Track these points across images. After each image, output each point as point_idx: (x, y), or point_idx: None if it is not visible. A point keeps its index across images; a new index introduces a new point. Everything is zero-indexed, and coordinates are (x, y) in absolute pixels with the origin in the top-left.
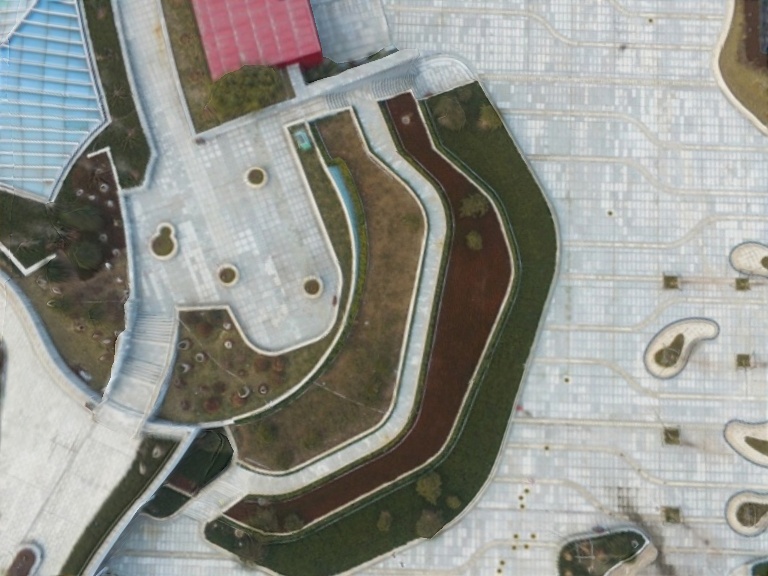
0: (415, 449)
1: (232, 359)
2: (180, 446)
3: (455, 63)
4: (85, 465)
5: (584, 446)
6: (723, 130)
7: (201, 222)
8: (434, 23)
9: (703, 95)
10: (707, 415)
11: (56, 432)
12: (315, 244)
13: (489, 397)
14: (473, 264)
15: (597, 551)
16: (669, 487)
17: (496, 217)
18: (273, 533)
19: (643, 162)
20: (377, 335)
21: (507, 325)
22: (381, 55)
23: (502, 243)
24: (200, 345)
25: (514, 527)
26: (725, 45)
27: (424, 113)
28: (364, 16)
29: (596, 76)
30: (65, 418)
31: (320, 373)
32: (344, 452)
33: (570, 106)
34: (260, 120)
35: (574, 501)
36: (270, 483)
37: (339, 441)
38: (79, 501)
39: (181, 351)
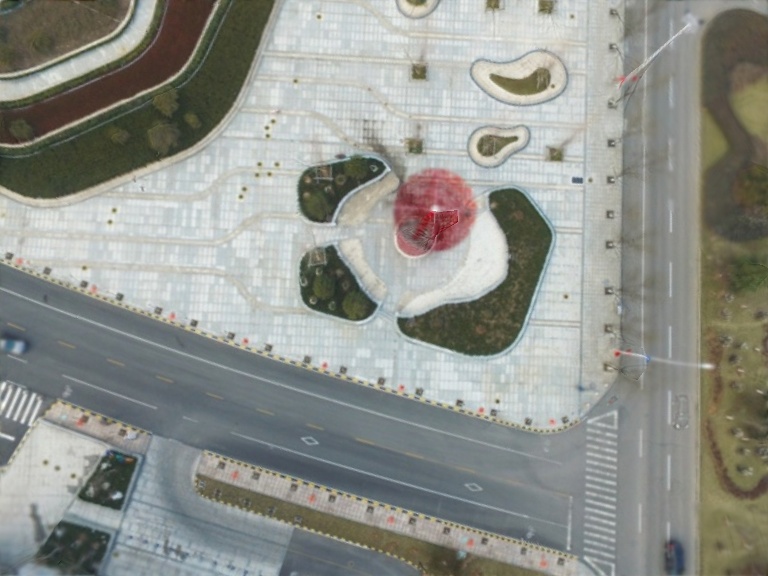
0: (154, 66)
1: None
2: None
3: None
4: None
5: (333, 80)
6: None
7: None
8: None
9: None
10: (455, 54)
11: None
12: None
13: (236, 24)
14: None
15: (336, 173)
16: (414, 121)
17: None
18: (3, 144)
19: None
20: None
21: None
22: None
23: None
24: None
25: (258, 155)
26: None
27: None
28: None
29: None
30: None
31: None
32: (77, 60)
33: None
34: None
35: (320, 132)
36: None
37: (72, 48)
38: None
39: None
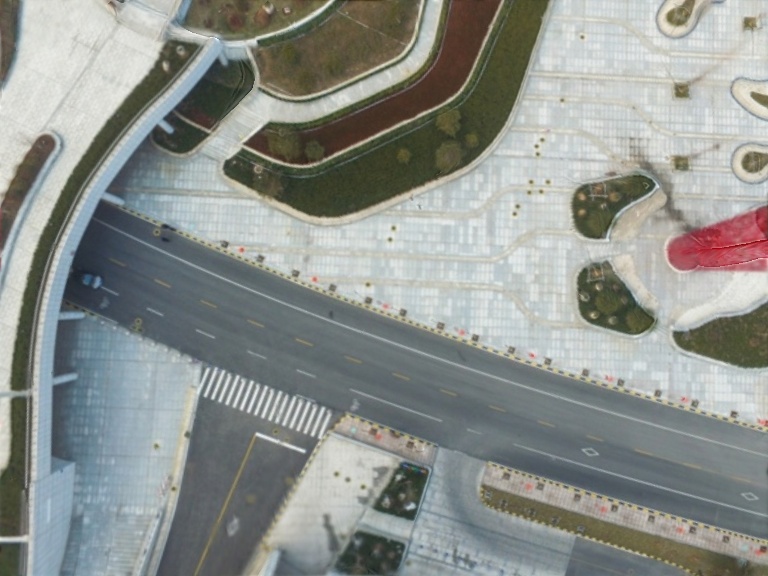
0: (435, 87)
1: None
2: (204, 50)
3: None
4: (107, 64)
5: (598, 99)
6: None
7: None
8: None
9: None
10: (715, 72)
11: (77, 31)
12: None
13: (508, 45)
14: None
15: (610, 190)
16: (678, 138)
17: None
18: (293, 165)
19: None
20: None
21: None
22: None
23: None
24: None
25: (529, 173)
26: None
27: None
28: None
29: None
30: (87, 19)
31: (344, 1)
32: (366, 83)
33: None
34: None
35: (588, 150)
36: (291, 109)
37: (361, 71)
38: (100, 97)
39: None
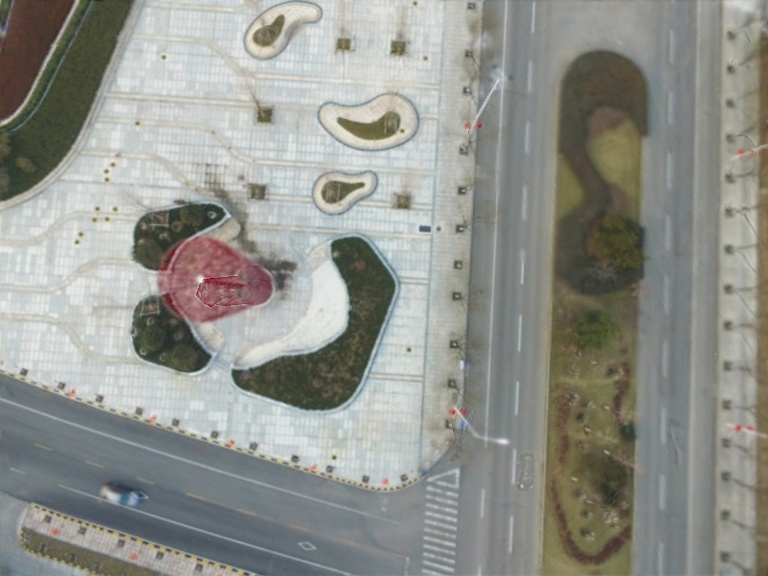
0: None
1: None
2: None
3: None
4: None
5: (176, 123)
6: None
7: None
8: None
9: None
10: (303, 96)
11: None
12: None
13: (75, 65)
14: None
15: (172, 220)
16: (258, 165)
17: None
18: None
19: None
20: None
21: None
22: None
23: None
24: None
25: (96, 200)
26: None
27: None
28: None
29: None
30: None
31: None
32: None
33: None
34: None
35: (160, 176)
36: None
37: None
38: None
39: None
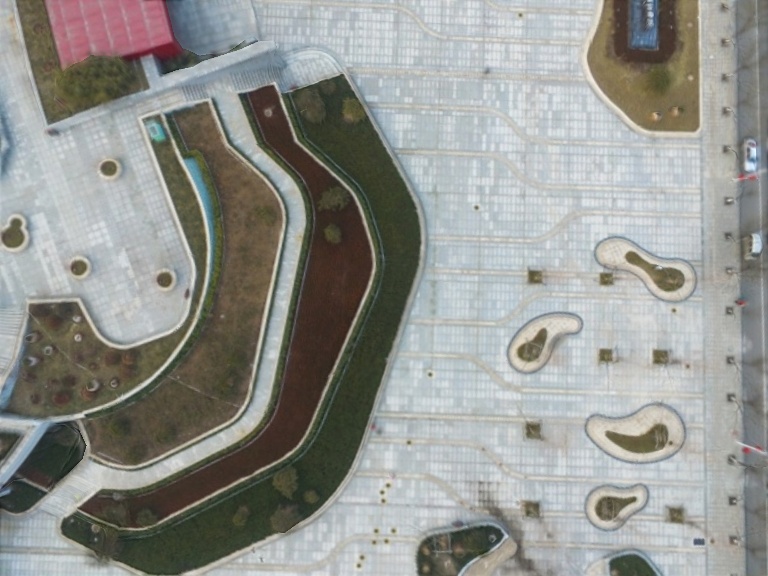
0: (273, 443)
1: (81, 352)
2: (24, 440)
3: (323, 56)
4: None
5: (446, 440)
6: (591, 125)
7: (54, 214)
8: (303, 16)
9: (571, 90)
10: (569, 409)
11: None
12: (170, 237)
13: (350, 391)
14: (333, 258)
15: (454, 545)
16: (530, 481)
17: (358, 211)
18: (128, 528)
19: (510, 156)
20: (233, 328)
21: (369, 319)
22: (241, 47)
23: (363, 237)
24: (50, 338)
25: (375, 522)
26: (594, 40)
27: (287, 106)
28: (232, 8)
29: (465, 70)
30: None
31: (174, 367)
32: (199, 446)
33: (438, 100)
34: (115, 111)
35: (435, 496)
36: (123, 477)
37: (193, 435)
38: None
39: (28, 344)
